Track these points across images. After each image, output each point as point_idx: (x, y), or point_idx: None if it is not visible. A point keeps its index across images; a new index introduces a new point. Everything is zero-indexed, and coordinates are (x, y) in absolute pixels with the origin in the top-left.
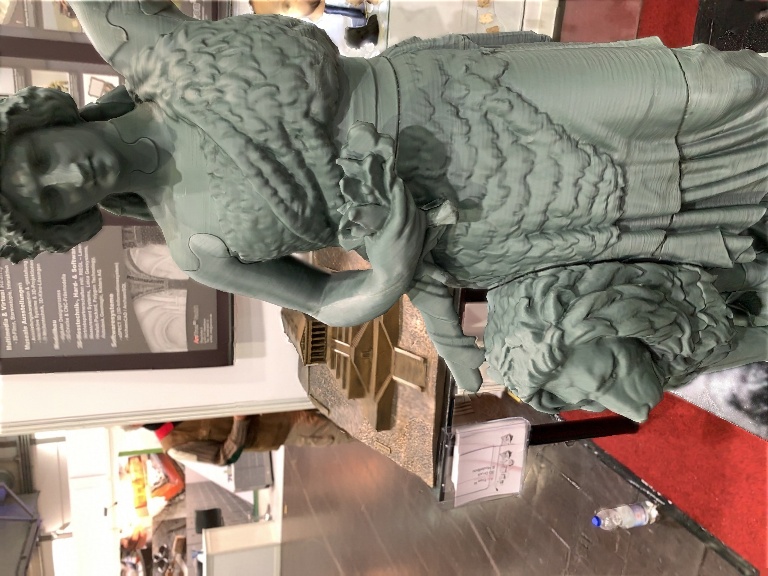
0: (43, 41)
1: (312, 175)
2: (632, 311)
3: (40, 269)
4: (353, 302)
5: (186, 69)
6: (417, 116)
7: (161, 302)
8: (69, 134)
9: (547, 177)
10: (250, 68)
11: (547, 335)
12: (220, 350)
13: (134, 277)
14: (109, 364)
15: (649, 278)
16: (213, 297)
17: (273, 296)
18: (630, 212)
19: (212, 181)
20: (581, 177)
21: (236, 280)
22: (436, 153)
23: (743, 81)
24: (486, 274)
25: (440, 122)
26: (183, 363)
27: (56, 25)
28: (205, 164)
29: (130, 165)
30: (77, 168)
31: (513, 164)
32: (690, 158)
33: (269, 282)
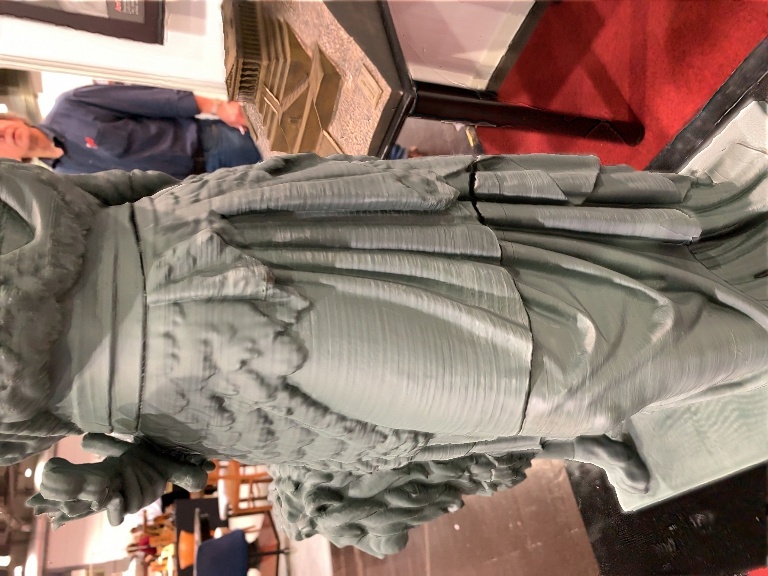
0: None
1: None
2: None
3: None
4: None
5: None
6: (163, 409)
7: None
8: None
9: (326, 451)
10: None
11: (300, 523)
12: (148, 24)
13: None
14: (13, 10)
15: (433, 479)
16: None
17: None
18: None
19: None
20: (370, 449)
21: None
22: (187, 434)
23: (596, 428)
24: None
25: (195, 413)
26: (103, 30)
27: None
28: None
29: None
30: None
31: (286, 442)
32: None
33: None
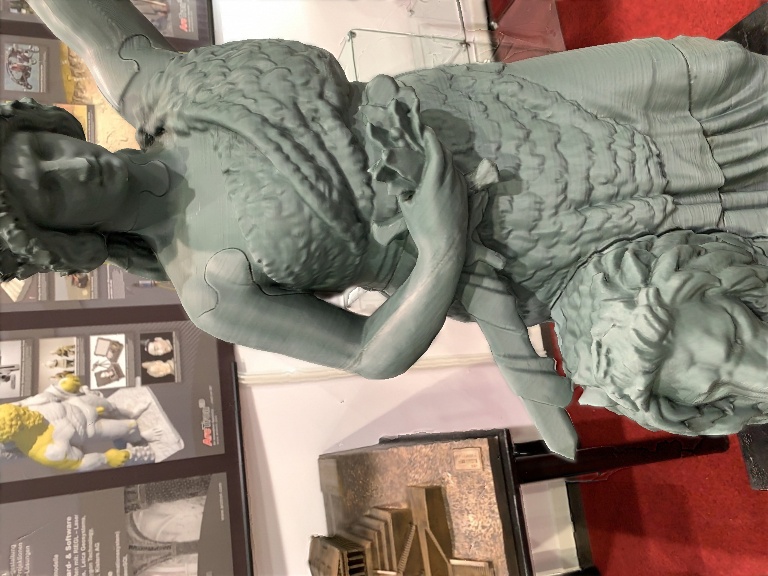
0: (53, 311)
1: (334, 160)
2: (726, 259)
3: (29, 552)
4: (401, 313)
5: (197, 75)
6: (431, 101)
7: (168, 574)
8: (76, 138)
9: (578, 143)
10: (260, 59)
11: (640, 297)
12: None
13: (137, 546)
14: None
15: None
16: (228, 558)
17: (306, 337)
18: (675, 183)
19: (228, 178)
20: (612, 142)
21: (261, 316)
22: (458, 129)
23: (731, 47)
24: (545, 264)
25: (455, 105)
26: None
27: (67, 296)
28: (220, 165)
29: (139, 184)
30: (82, 158)
31: (539, 134)
32: (711, 134)
33: (300, 315)
